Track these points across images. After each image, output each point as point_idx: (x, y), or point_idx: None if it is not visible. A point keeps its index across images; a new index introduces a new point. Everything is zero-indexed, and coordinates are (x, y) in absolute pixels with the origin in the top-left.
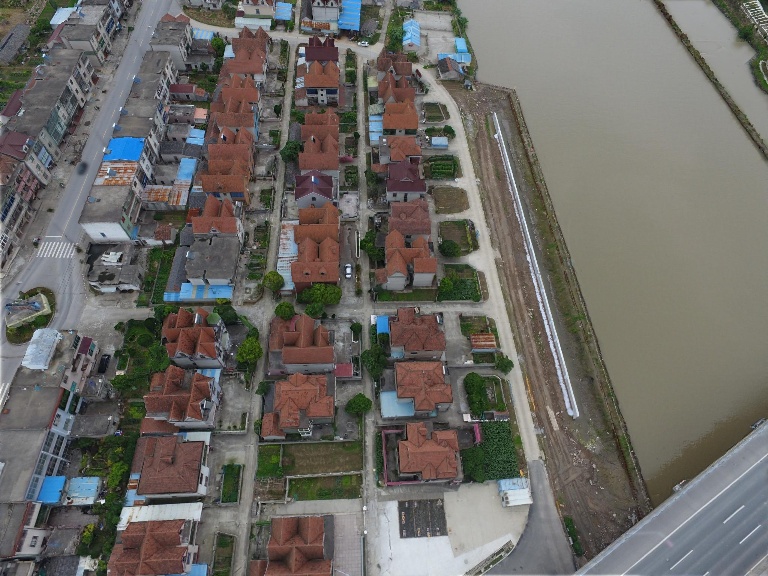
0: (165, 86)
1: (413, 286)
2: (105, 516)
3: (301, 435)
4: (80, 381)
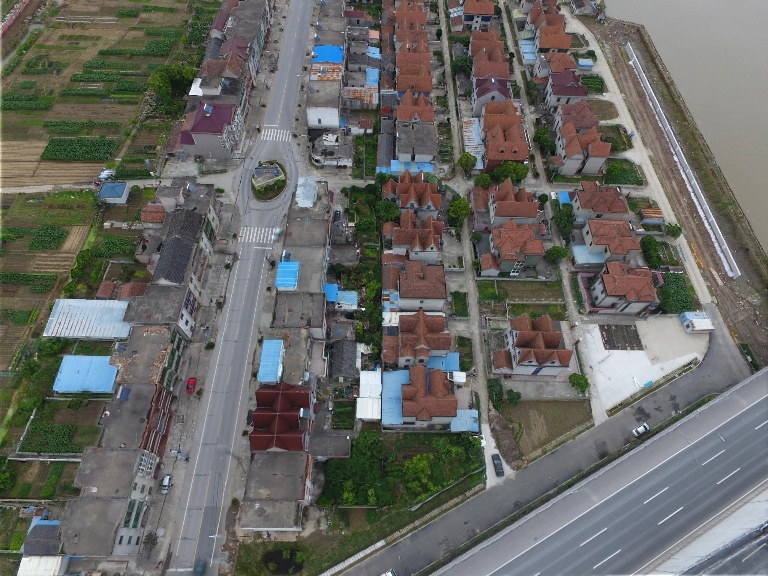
0: None
1: (582, 173)
2: (364, 321)
3: (510, 274)
4: None
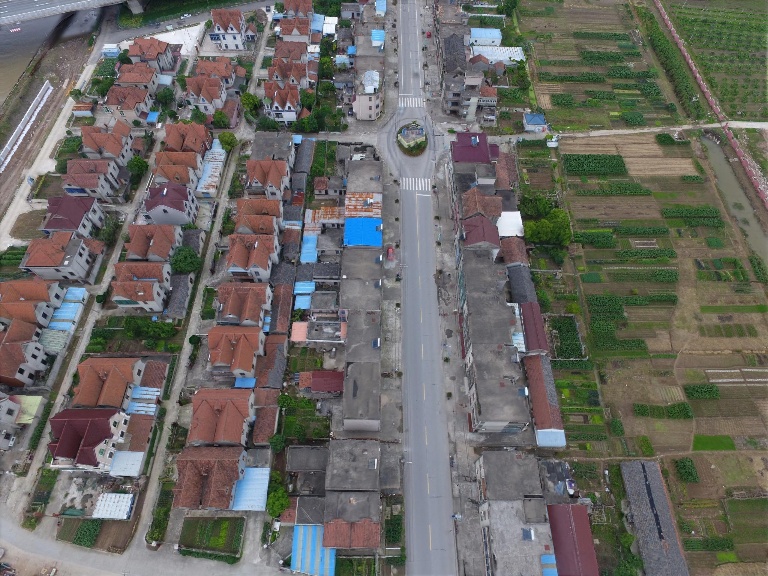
0: None
1: None
2: None
3: None
4: None
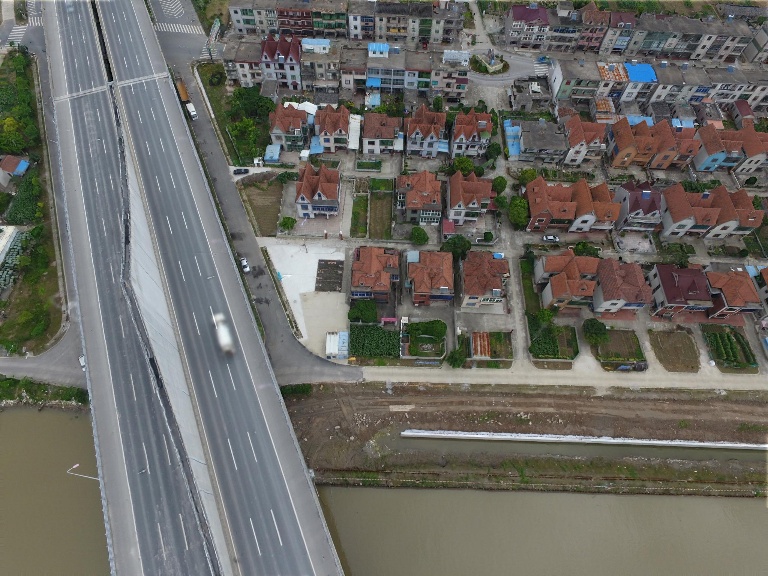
0: (738, 94)
1: (542, 293)
2: None
3: None
4: (440, 87)
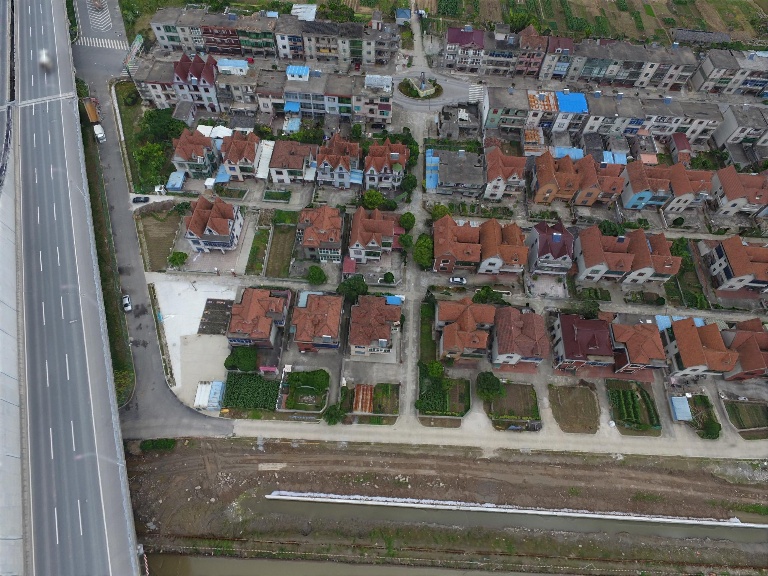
0: (675, 126)
1: None
2: None
3: None
4: (363, 113)
